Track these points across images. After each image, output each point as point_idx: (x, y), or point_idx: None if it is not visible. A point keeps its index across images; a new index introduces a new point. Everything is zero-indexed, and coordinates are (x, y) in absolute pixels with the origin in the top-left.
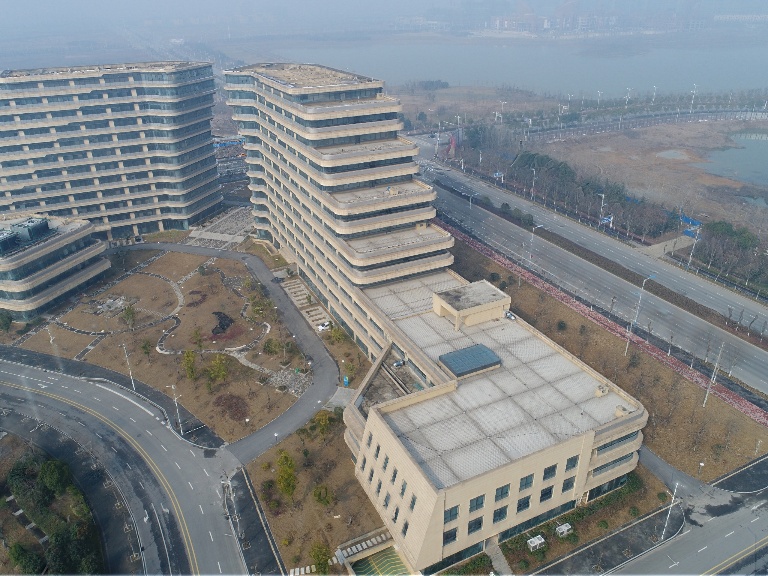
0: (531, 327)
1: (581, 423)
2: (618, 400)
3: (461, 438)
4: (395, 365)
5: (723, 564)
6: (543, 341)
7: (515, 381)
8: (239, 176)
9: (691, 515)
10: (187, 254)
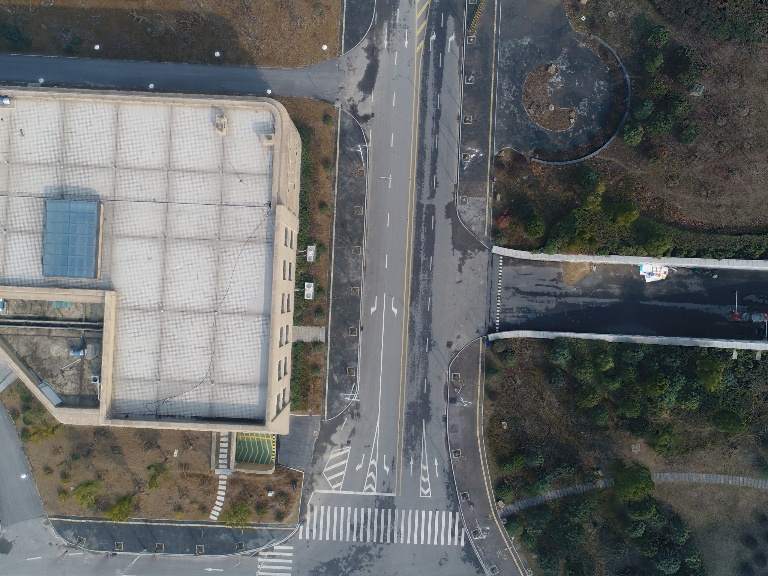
0: (44, 95)
1: (253, 194)
2: (244, 118)
3: (200, 343)
4: (1, 310)
5: (413, 139)
6: (82, 102)
7: (141, 208)
8: None
9: (358, 112)
10: None
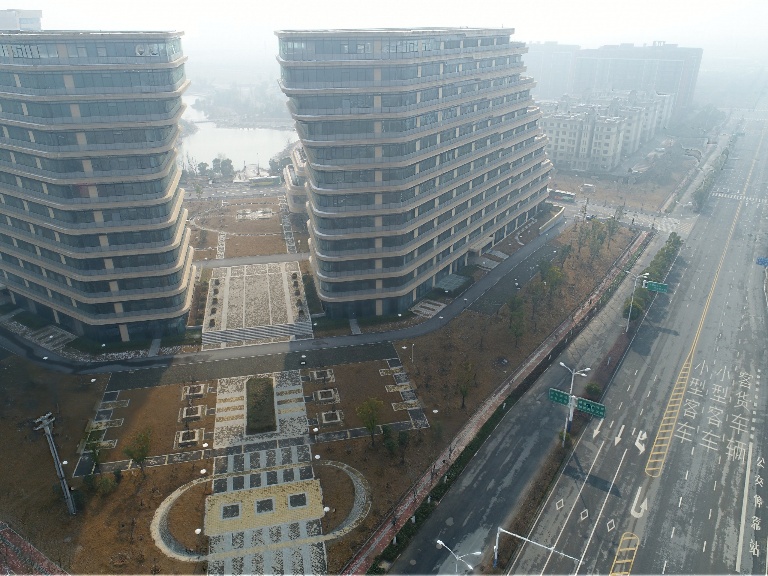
0: None
1: None
2: None
3: None
4: None
5: None
6: None
7: None
8: (528, 468)
9: None
10: (260, 253)
